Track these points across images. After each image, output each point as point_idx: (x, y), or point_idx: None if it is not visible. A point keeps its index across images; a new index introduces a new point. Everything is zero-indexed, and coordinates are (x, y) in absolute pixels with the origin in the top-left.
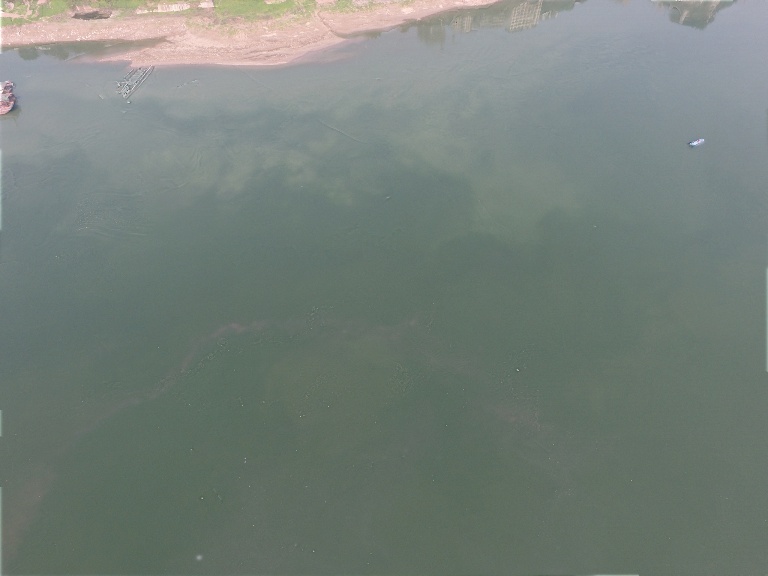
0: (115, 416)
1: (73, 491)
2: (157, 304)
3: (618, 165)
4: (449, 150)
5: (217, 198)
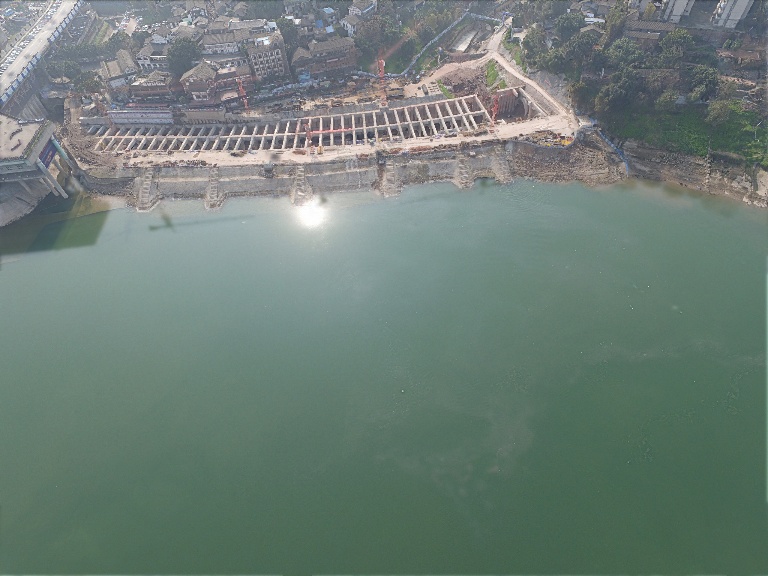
0: None
1: (749, 284)
2: None
3: None
4: None
5: None
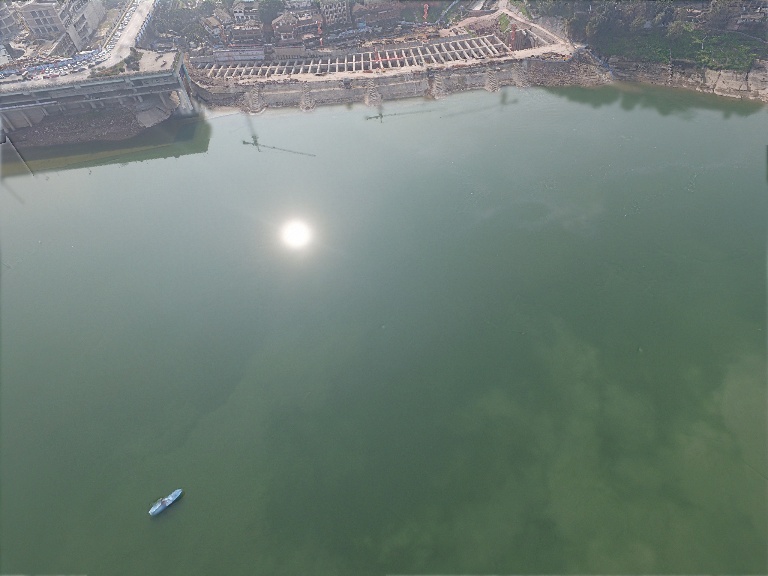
0: (717, 154)
1: (701, 132)
2: None
3: (318, 443)
4: (591, 465)
5: None
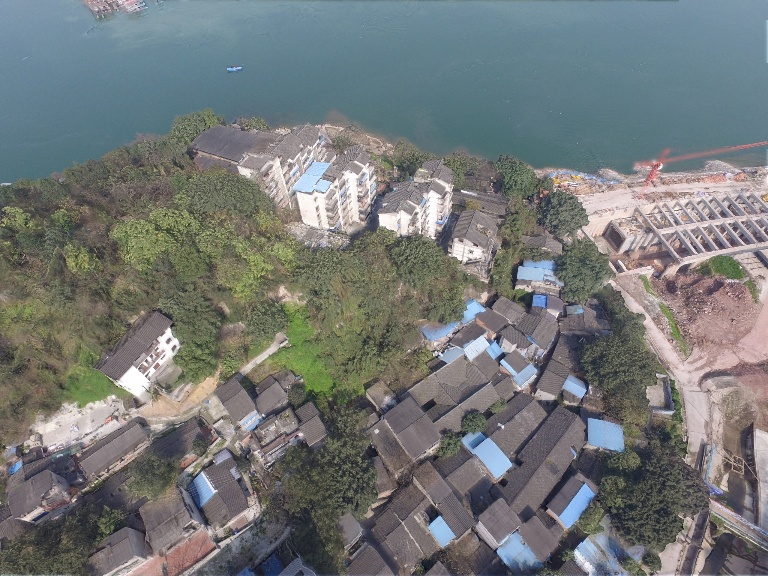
0: (439, 82)
1: (435, 101)
2: (433, 50)
3: None
4: None
5: (435, 19)
